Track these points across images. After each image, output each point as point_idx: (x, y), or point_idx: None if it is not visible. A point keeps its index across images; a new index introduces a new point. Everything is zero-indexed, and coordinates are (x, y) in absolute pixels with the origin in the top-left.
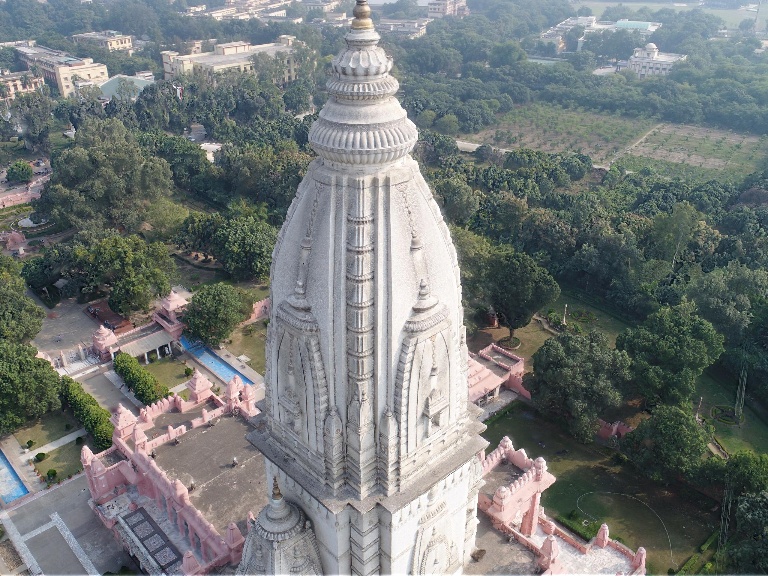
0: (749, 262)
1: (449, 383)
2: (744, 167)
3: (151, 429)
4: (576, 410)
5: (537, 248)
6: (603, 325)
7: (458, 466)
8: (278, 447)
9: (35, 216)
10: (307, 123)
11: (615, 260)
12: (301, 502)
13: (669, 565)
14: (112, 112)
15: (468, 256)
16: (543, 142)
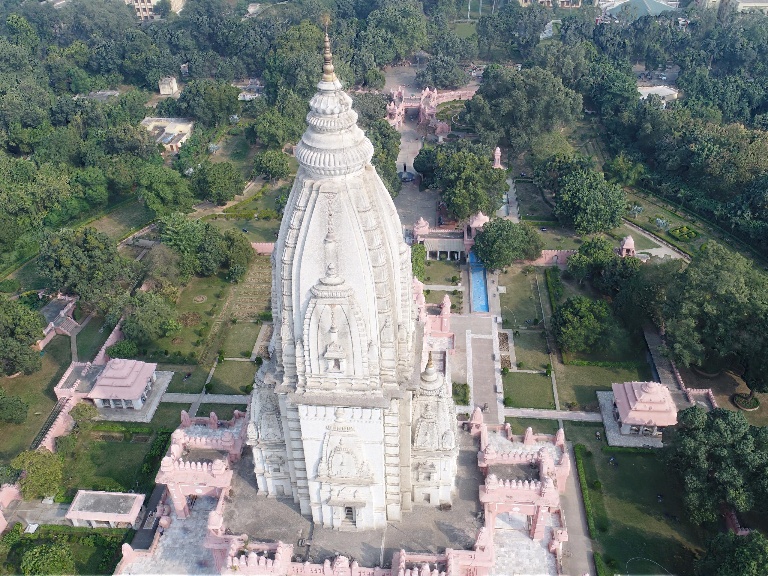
0: None
1: (352, 345)
2: None
3: None
4: None
5: None
6: None
7: (353, 406)
8: None
9: (463, 114)
10: None
11: None
12: None
13: None
14: (598, 34)
15: None
16: None
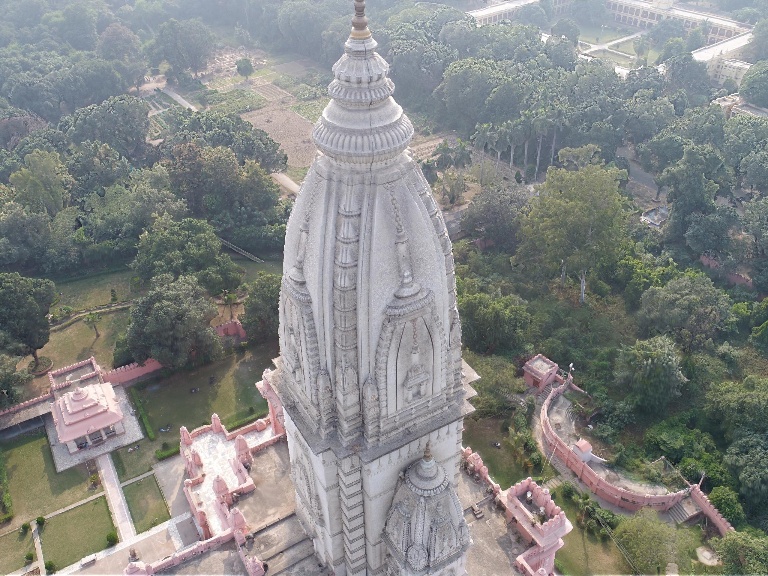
0: None
1: None
2: None
3: None
4: (209, 338)
5: None
6: (73, 293)
7: None
8: (394, 436)
9: None
10: None
11: (27, 236)
12: (417, 455)
13: None
14: None
15: None
16: None
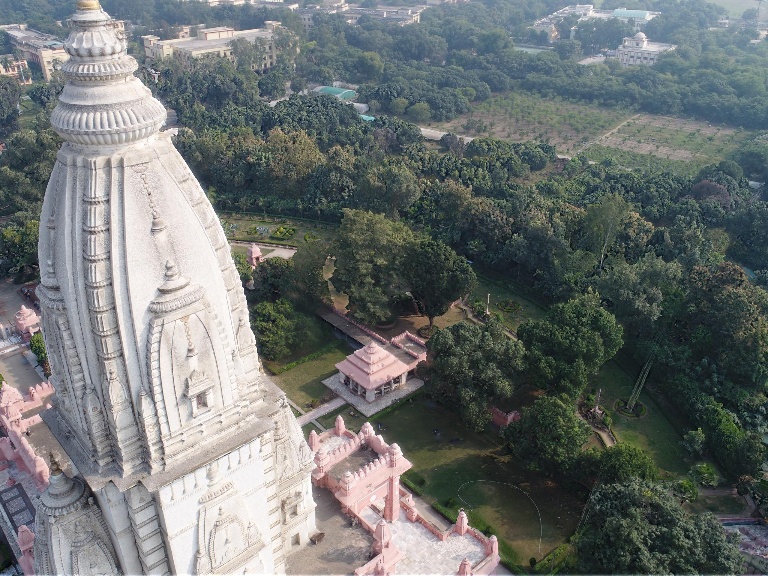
0: (677, 255)
1: (216, 365)
2: (711, 159)
3: (38, 407)
4: (465, 399)
5: (475, 237)
6: (527, 315)
7: (235, 447)
8: (64, 424)
9: None
10: (275, 109)
11: (543, 250)
12: None
13: (535, 554)
14: None
15: (381, 243)
16: (513, 131)
